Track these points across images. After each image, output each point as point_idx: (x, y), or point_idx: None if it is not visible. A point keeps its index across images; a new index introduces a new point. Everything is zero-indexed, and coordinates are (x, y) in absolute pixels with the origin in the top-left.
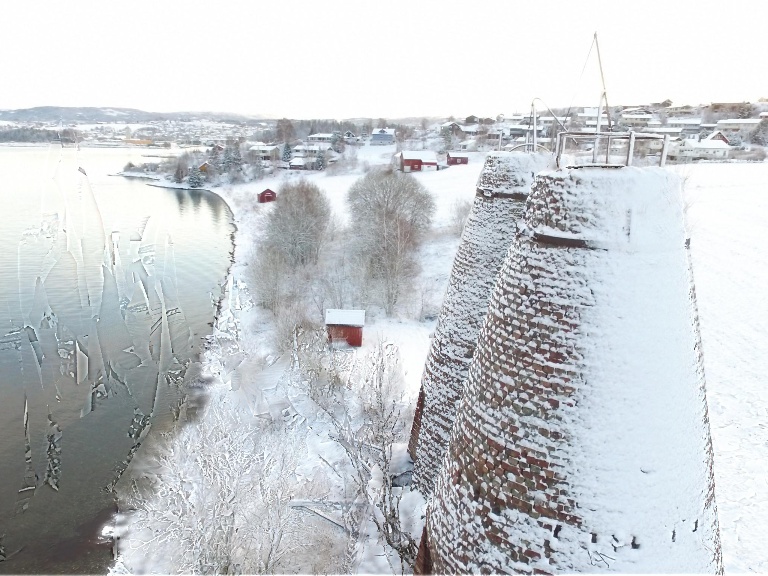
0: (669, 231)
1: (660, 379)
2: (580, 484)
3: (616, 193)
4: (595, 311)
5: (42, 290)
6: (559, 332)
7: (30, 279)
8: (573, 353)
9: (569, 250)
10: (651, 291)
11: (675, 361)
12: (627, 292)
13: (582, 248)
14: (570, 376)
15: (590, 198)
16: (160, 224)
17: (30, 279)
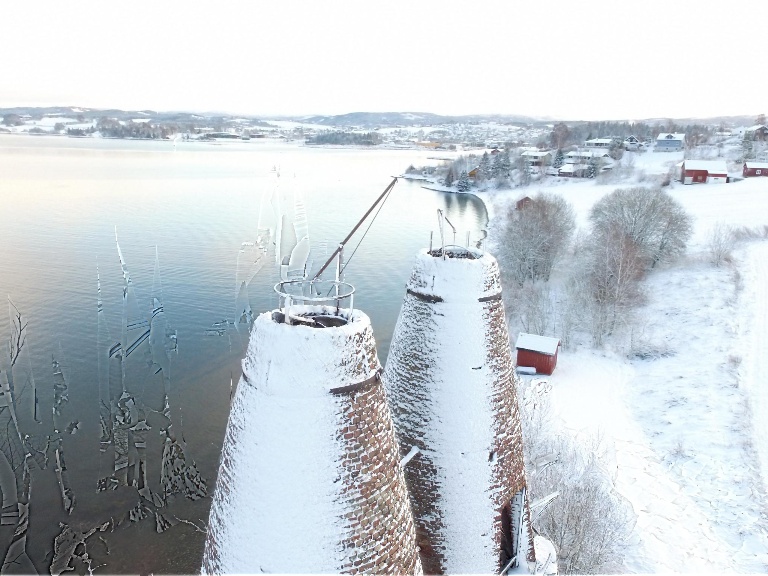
0: (303, 382)
1: (282, 500)
2: (225, 564)
3: (266, 345)
4: (243, 434)
5: (245, 292)
6: (229, 443)
7: (245, 281)
8: (232, 462)
9: (243, 382)
10: (280, 428)
11: (299, 489)
12: (262, 425)
13: (247, 382)
14: (229, 479)
15: (255, 345)
16: (305, 254)
17: (245, 281)
